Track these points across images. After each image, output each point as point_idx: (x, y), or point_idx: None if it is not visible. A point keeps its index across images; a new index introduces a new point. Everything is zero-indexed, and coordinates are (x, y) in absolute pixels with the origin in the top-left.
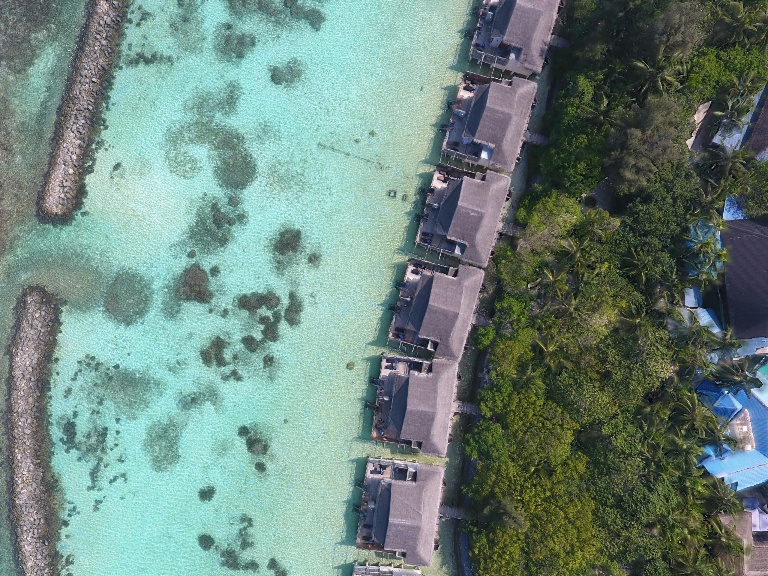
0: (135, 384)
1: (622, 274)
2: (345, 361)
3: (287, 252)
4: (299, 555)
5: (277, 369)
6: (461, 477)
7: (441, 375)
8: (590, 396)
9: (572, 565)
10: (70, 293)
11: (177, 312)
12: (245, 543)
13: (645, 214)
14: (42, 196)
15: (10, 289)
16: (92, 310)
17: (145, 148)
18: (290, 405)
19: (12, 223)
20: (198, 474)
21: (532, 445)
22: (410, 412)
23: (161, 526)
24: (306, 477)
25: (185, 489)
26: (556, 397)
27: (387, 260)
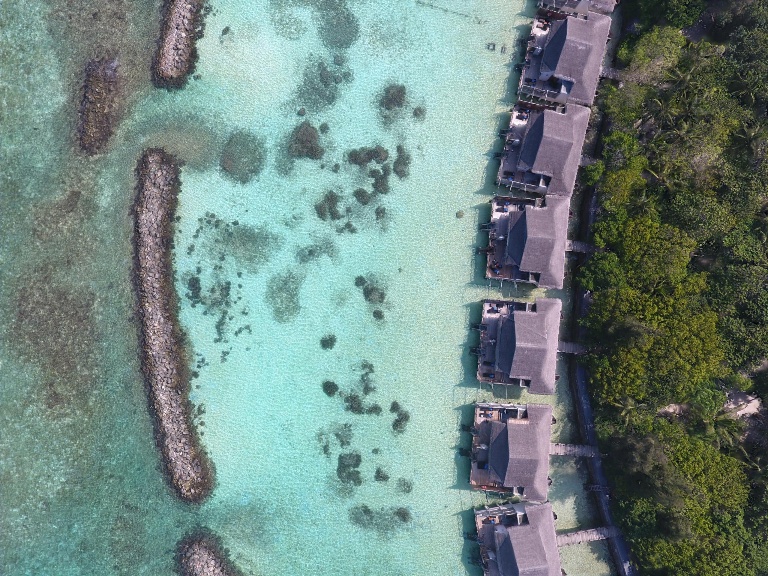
0: (254, 239)
1: (731, 96)
2: (454, 210)
3: (393, 107)
4: (420, 398)
5: (389, 220)
6: (573, 317)
7: (556, 208)
8: (709, 210)
9: (697, 379)
10: (188, 154)
11: (290, 169)
12: (368, 388)
13: (749, 39)
14: (157, 61)
15: (130, 152)
16: (209, 169)
17: (251, 12)
18: (404, 254)
19: (129, 88)
20: (319, 323)
21: (651, 267)
22: (530, 240)
23: (287, 374)
24: (423, 323)
25: (307, 338)
26: (671, 220)
27: (489, 111)
